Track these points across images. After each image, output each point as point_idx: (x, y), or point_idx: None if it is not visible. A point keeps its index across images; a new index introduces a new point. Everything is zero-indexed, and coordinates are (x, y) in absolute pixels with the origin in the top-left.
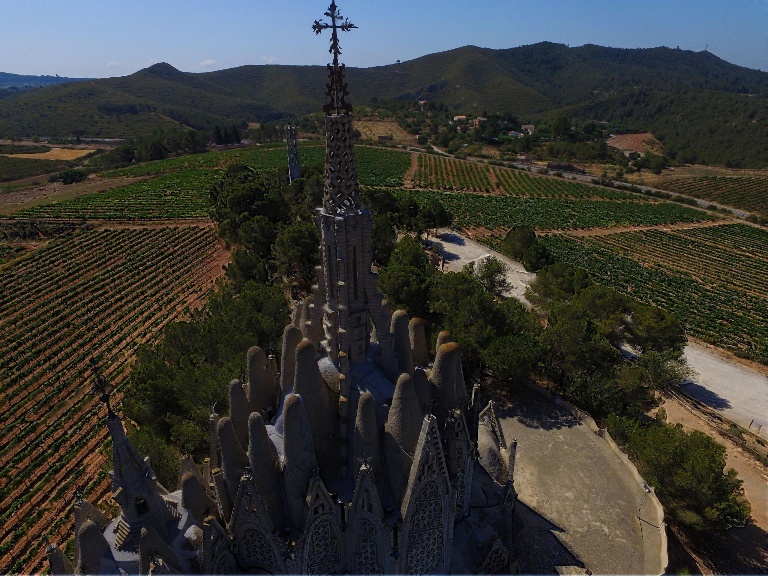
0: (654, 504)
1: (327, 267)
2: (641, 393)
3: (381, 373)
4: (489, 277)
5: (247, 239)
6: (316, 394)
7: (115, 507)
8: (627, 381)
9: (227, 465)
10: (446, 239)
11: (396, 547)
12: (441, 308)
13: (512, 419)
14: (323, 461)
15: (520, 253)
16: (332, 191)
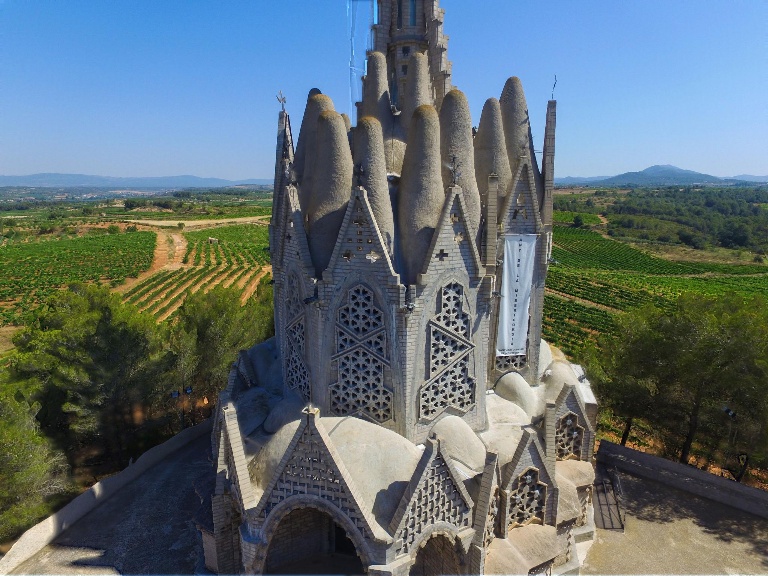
0: None
1: None
2: None
3: None
4: None
5: None
6: None
7: None
8: None
9: None
10: None
11: None
12: None
13: None
14: None
15: None
16: None
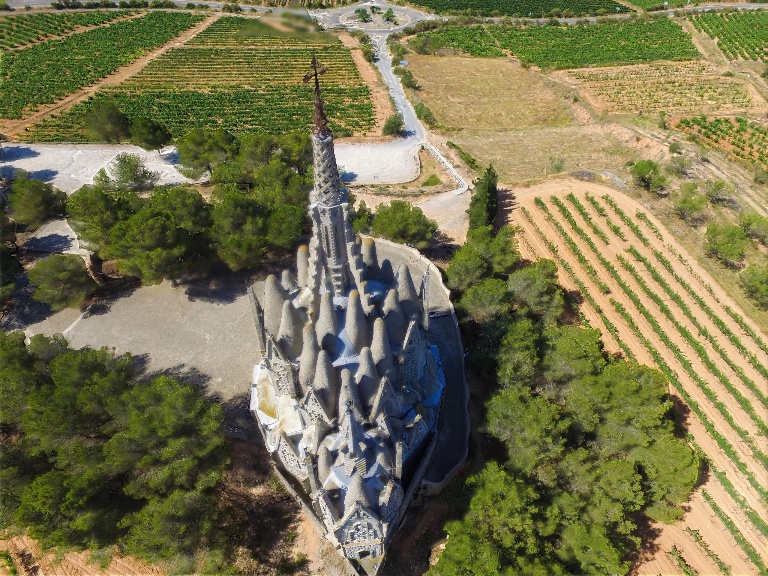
0: (409, 251)
1: (334, 240)
2: None
3: None
4: None
5: None
6: None
7: (181, 569)
8: None
9: None
10: (6, 158)
11: None
12: (187, 229)
13: None
14: None
15: (113, 134)
16: (334, 190)
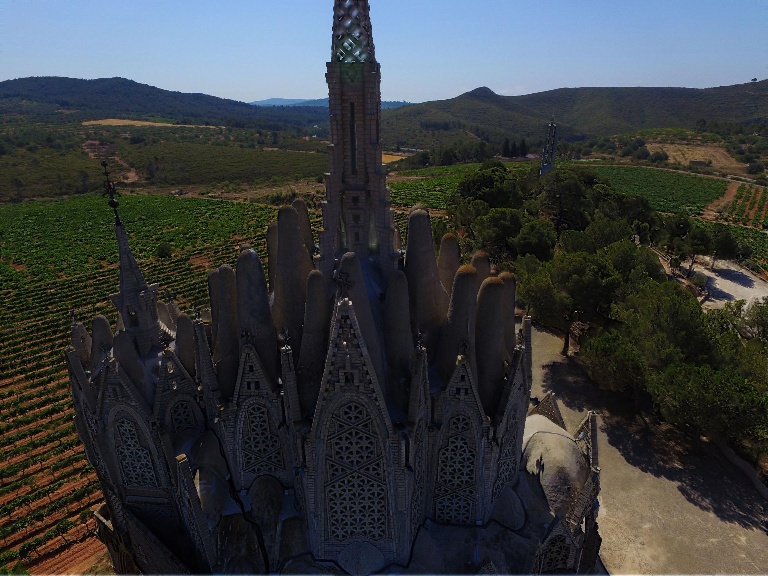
0: None
1: None
2: None
3: (376, 276)
4: (763, 325)
5: (462, 221)
6: (292, 270)
7: None
8: None
9: (212, 318)
10: (725, 275)
11: (304, 464)
12: (630, 319)
13: (669, 482)
14: (292, 351)
15: None
16: (334, 32)
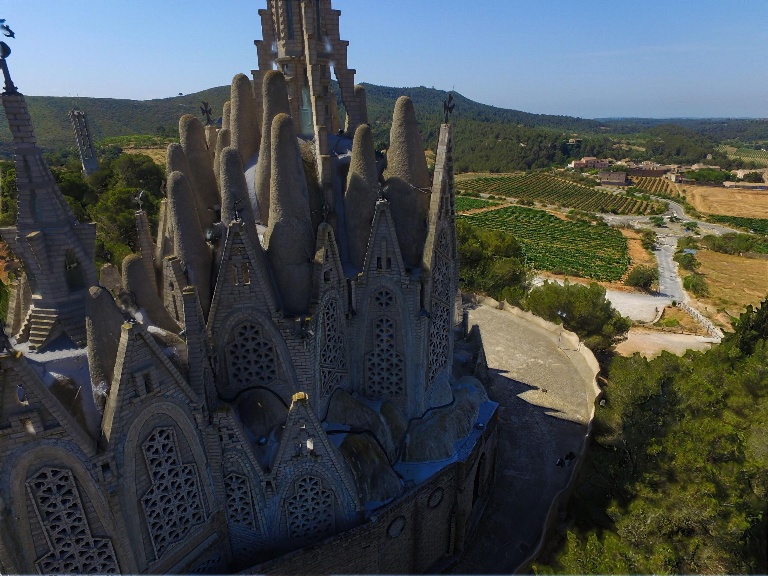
0: (566, 337)
1: None
2: (516, 279)
3: None
4: None
5: None
6: None
7: None
8: (504, 270)
9: (188, 245)
10: None
11: (423, 308)
12: None
13: None
14: None
15: None
16: None
